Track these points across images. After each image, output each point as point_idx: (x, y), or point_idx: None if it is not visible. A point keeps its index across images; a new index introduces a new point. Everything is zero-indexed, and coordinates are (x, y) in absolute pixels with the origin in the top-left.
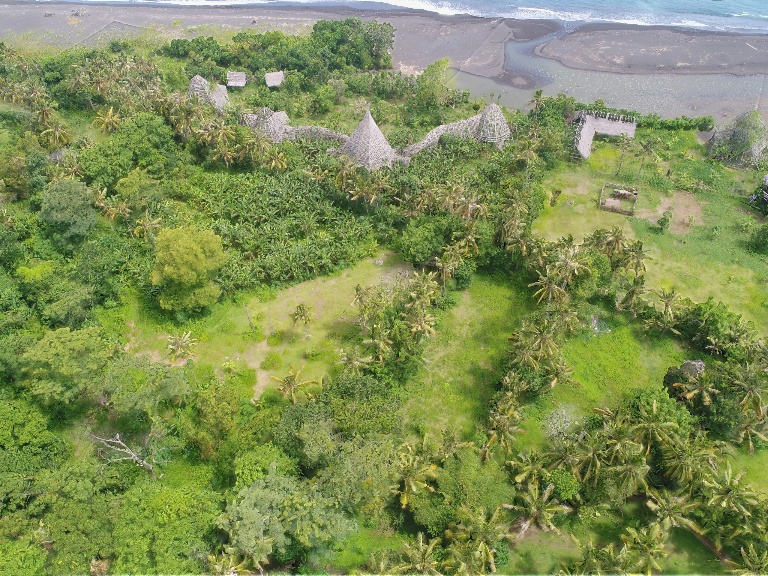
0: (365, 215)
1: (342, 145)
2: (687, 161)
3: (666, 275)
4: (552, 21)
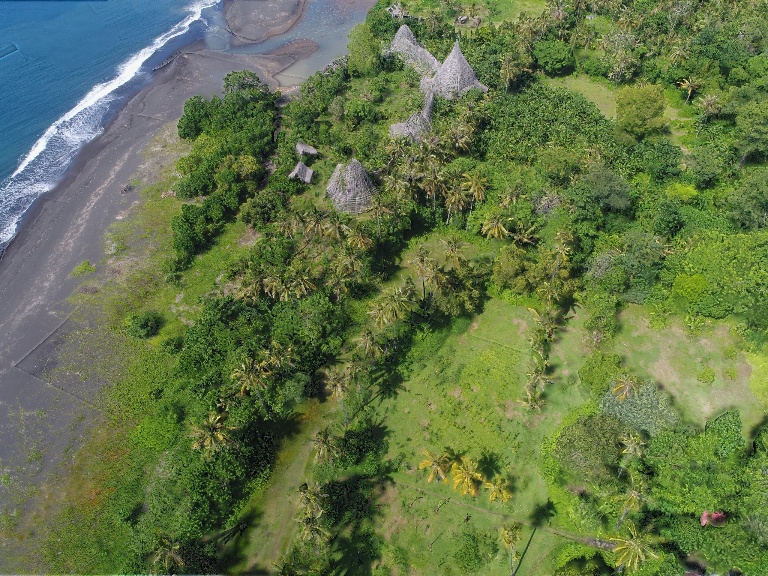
0: (523, 85)
1: (438, 97)
2: (424, 4)
3: None
4: (194, 35)
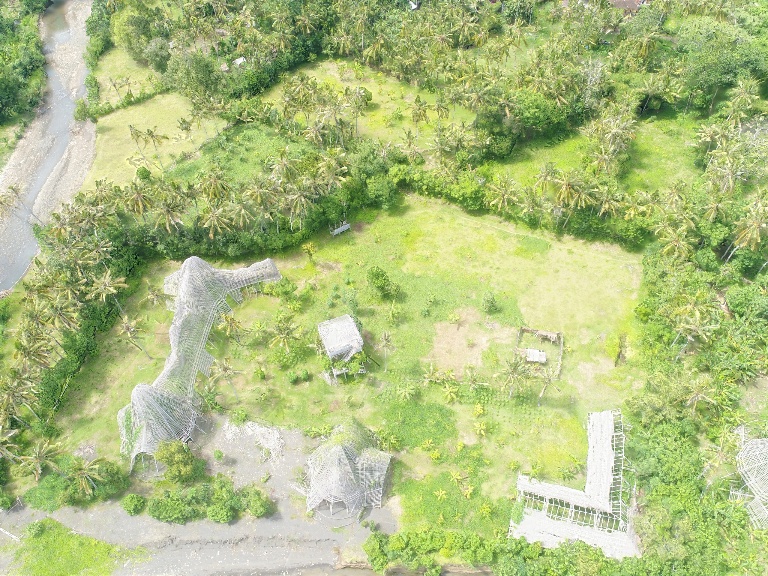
0: None
1: None
2: None
3: (489, 257)
4: None
